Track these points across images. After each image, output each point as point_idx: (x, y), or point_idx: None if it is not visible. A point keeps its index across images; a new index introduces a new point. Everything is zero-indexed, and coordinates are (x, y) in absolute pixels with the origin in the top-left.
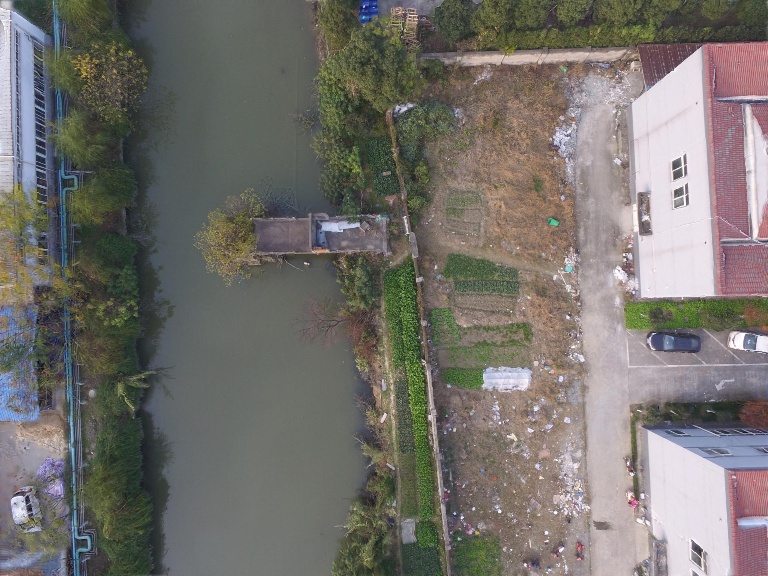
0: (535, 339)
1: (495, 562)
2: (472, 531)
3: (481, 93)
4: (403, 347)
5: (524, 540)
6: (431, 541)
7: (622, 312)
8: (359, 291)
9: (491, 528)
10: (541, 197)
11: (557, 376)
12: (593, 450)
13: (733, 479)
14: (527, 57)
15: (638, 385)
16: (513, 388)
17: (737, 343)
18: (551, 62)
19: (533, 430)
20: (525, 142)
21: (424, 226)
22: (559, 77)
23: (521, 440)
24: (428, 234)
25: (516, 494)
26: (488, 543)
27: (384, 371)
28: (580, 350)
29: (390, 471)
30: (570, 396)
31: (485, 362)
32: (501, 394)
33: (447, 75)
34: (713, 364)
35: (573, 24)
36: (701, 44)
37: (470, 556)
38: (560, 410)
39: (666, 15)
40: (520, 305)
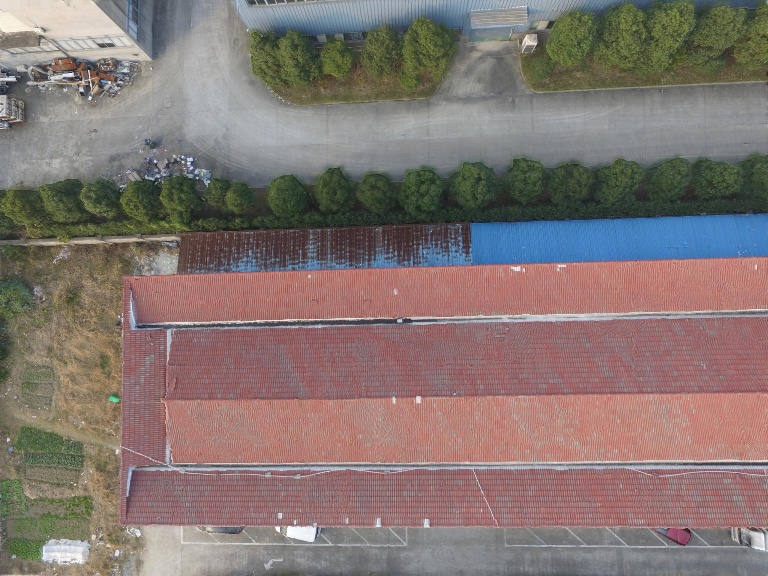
0: (95, 513)
1: None
2: None
3: (60, 271)
4: None
5: None
6: None
7: None
8: None
9: None
10: (105, 374)
11: (113, 550)
12: None
13: None
14: (91, 241)
15: (190, 562)
16: (72, 561)
17: None
18: (123, 242)
19: None
20: (93, 320)
21: (2, 399)
22: (131, 256)
23: None
24: (4, 407)
25: None
26: None
27: None
28: None
29: None
30: (125, 570)
31: (48, 534)
32: (60, 566)
33: (26, 256)
34: (262, 543)
35: (111, 218)
36: (240, 232)
37: None
38: None
39: (185, 213)
40: (83, 478)
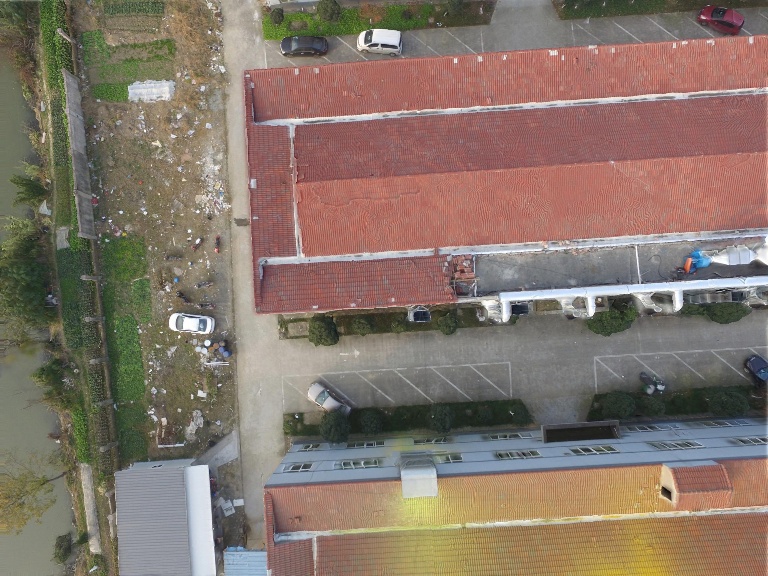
0: (178, 53)
1: (140, 260)
2: (120, 233)
3: None
4: (57, 68)
5: (168, 239)
6: (81, 244)
7: (260, 25)
8: (1, 6)
9: (137, 229)
10: None
11: (199, 86)
12: (234, 153)
13: (247, 77)
14: None
15: None
16: (158, 99)
17: (360, 41)
18: None
19: (176, 136)
20: None
21: None
22: None
23: (165, 146)
24: None
25: (160, 196)
26: (134, 243)
27: (43, 94)
28: (221, 62)
29: (48, 185)
30: (211, 104)
31: (132, 76)
32: (146, 105)
33: None
34: None
35: None
36: None
37: (118, 256)
38: (202, 117)
39: None
40: (165, 23)
